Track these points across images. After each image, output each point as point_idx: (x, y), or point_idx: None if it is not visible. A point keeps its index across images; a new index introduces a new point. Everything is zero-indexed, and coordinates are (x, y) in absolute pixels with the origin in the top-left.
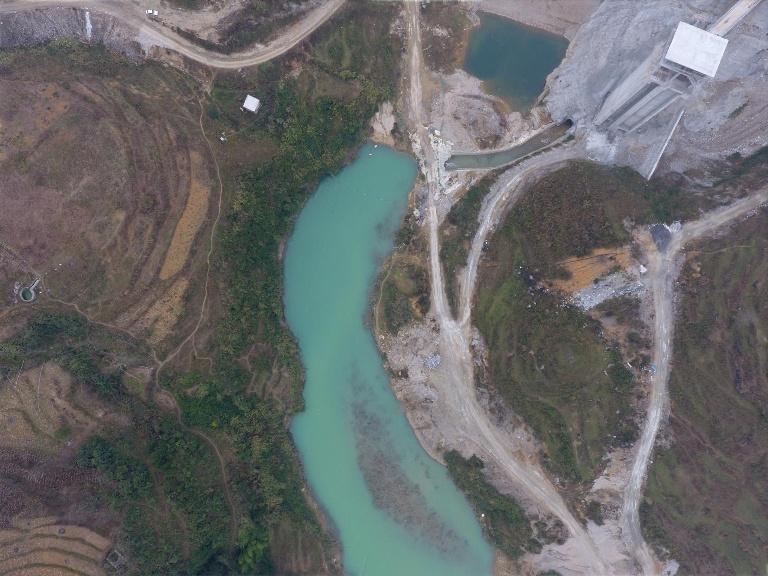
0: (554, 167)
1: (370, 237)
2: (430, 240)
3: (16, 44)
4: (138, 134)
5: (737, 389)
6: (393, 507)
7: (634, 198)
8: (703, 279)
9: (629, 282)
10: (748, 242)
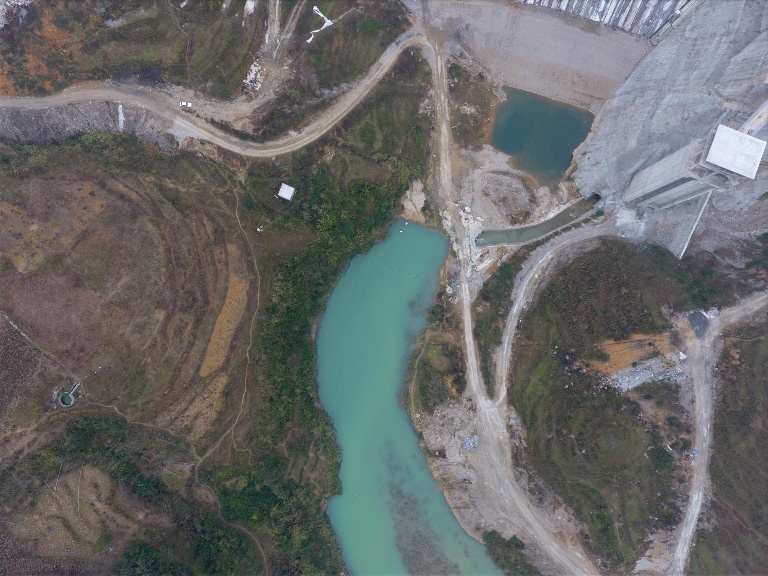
0: (586, 246)
1: (403, 315)
2: (463, 317)
3: (47, 137)
4: (175, 230)
5: None
6: None
7: (670, 283)
8: (742, 367)
9: (668, 367)
10: None
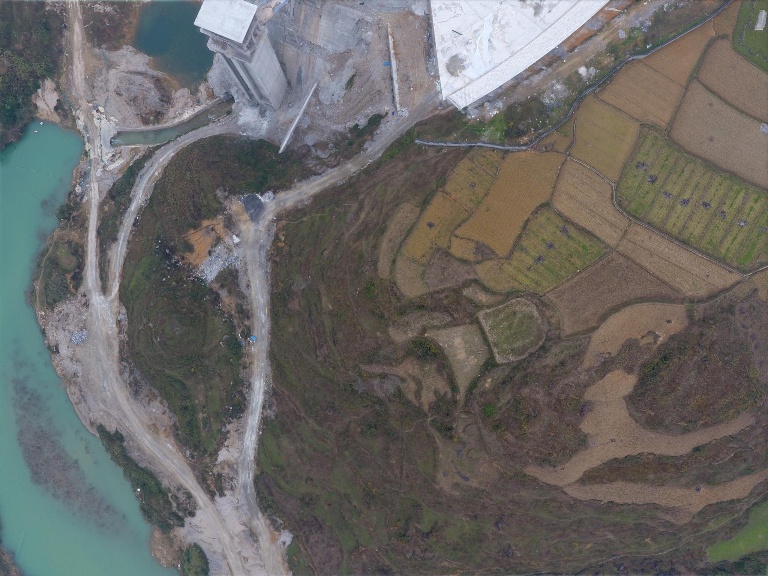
0: None
1: (34, 214)
2: (89, 216)
3: None
4: None
5: None
6: (51, 482)
7: (238, 169)
8: (285, 248)
9: (229, 253)
10: (322, 210)
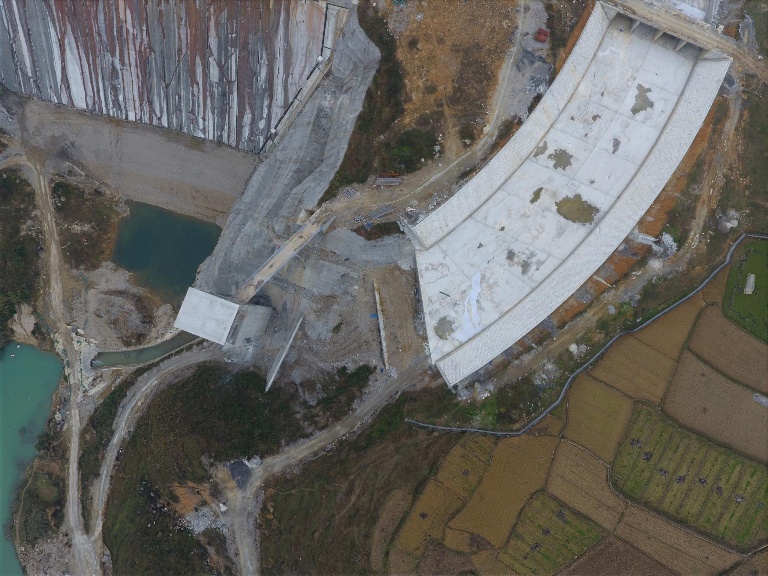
0: (180, 375)
1: (12, 442)
2: (70, 446)
3: None
4: None
5: None
6: None
7: (224, 427)
8: (274, 522)
9: (216, 517)
10: (311, 486)
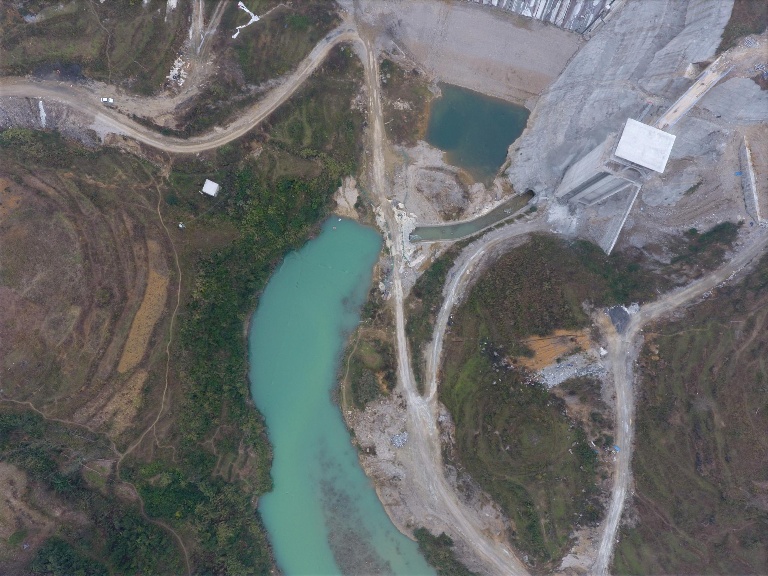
0: (516, 242)
1: (336, 311)
2: (396, 314)
3: None
4: (93, 226)
5: (698, 471)
6: None
7: (593, 279)
8: (661, 362)
9: (590, 363)
10: (704, 326)
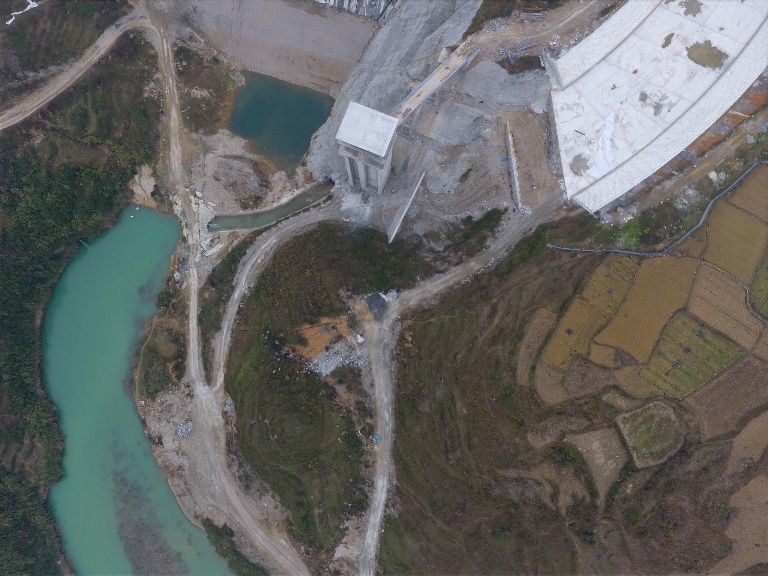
0: (303, 230)
1: (131, 301)
2: (189, 303)
3: None
4: None
5: (448, 459)
6: None
7: (358, 266)
8: (413, 349)
9: (351, 351)
10: (452, 312)
